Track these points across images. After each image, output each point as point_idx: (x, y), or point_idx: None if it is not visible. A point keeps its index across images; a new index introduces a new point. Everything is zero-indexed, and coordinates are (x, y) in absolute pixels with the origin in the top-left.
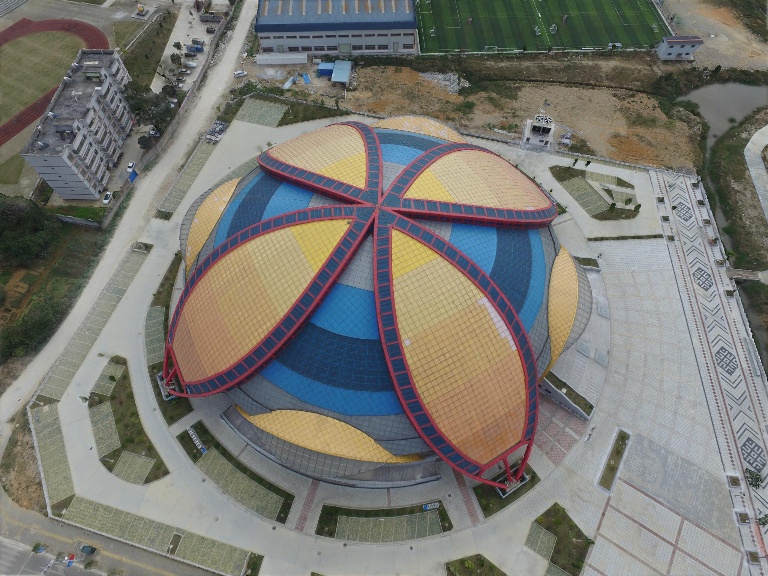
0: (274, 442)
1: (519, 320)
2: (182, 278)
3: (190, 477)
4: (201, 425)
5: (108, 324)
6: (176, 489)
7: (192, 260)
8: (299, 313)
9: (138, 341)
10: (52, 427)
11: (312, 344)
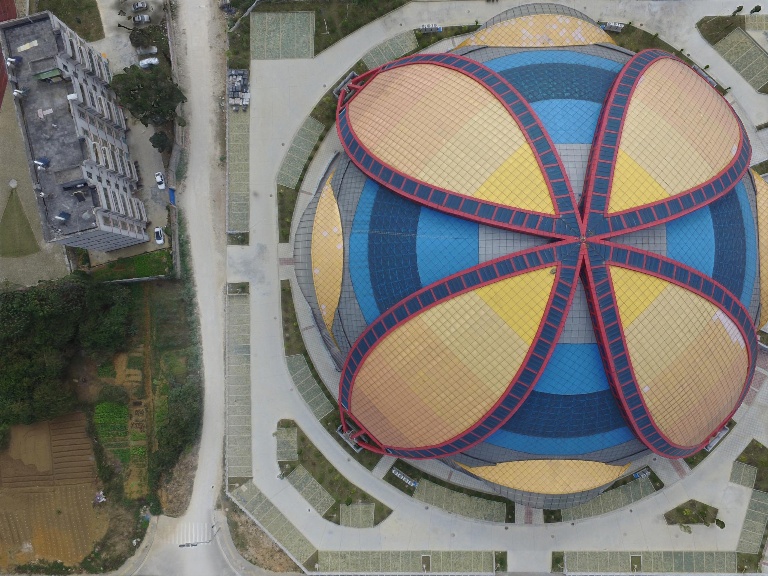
0: (511, 492)
1: (749, 316)
2: (305, 316)
3: (413, 509)
4: (401, 462)
5: (253, 389)
6: (405, 522)
7: (331, 318)
8: (521, 391)
9: (295, 398)
10: (261, 502)
11: (535, 408)
